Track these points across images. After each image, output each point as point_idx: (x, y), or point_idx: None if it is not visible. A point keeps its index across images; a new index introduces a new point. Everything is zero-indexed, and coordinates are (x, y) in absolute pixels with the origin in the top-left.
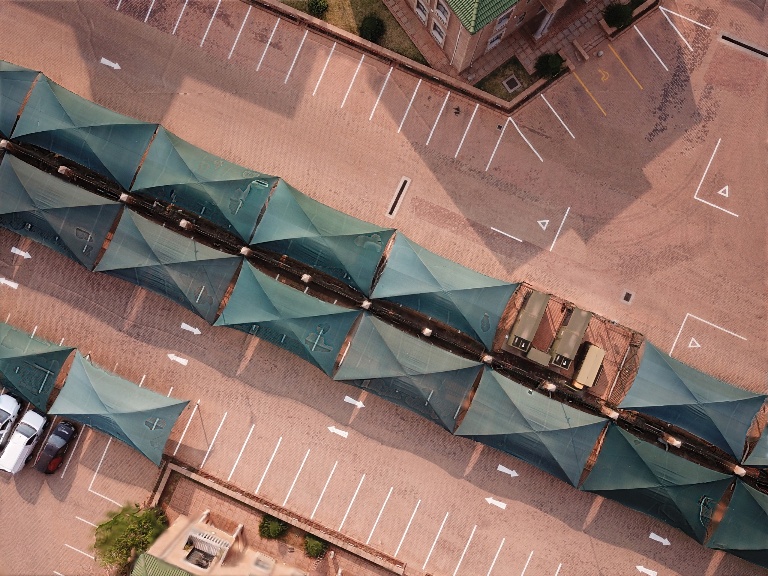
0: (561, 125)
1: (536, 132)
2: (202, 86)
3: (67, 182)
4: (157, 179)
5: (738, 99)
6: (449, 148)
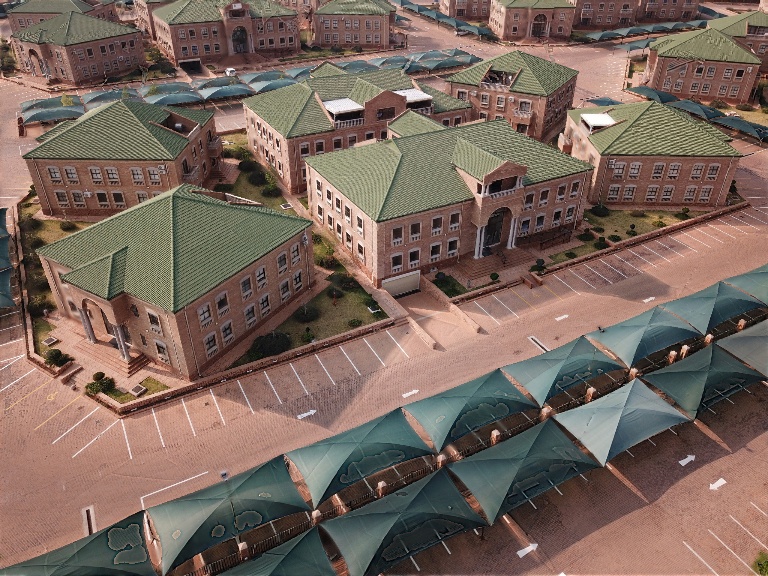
0: (762, 198)
1: (764, 204)
2: (685, 276)
3: (752, 326)
4: (767, 286)
5: (765, 165)
6: (764, 225)
